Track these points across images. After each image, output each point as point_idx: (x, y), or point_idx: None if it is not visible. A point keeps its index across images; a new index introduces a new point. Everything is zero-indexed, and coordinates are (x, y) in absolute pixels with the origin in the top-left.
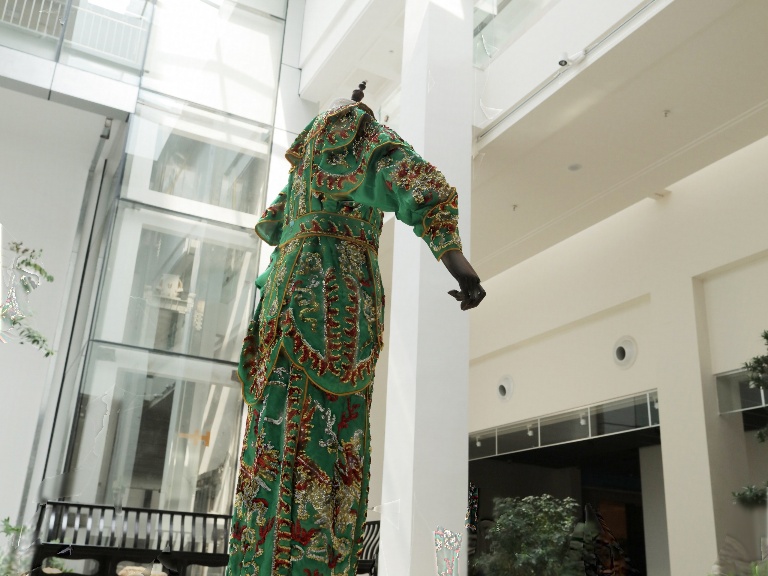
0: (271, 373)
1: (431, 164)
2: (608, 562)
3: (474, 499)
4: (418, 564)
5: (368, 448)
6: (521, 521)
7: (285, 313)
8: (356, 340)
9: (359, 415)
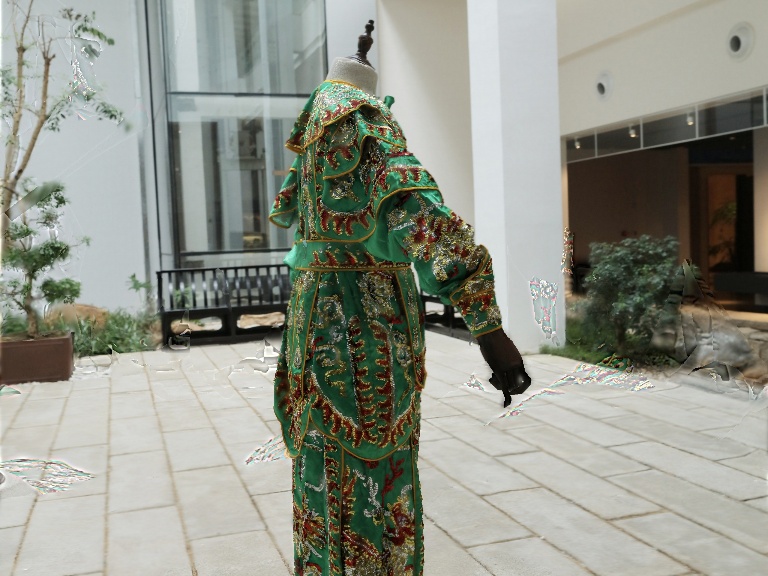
0: (305, 436)
1: (454, 221)
2: (706, 326)
3: (569, 244)
4: (516, 313)
5: (418, 497)
6: (618, 268)
7: (310, 370)
8: (391, 397)
9: (404, 470)
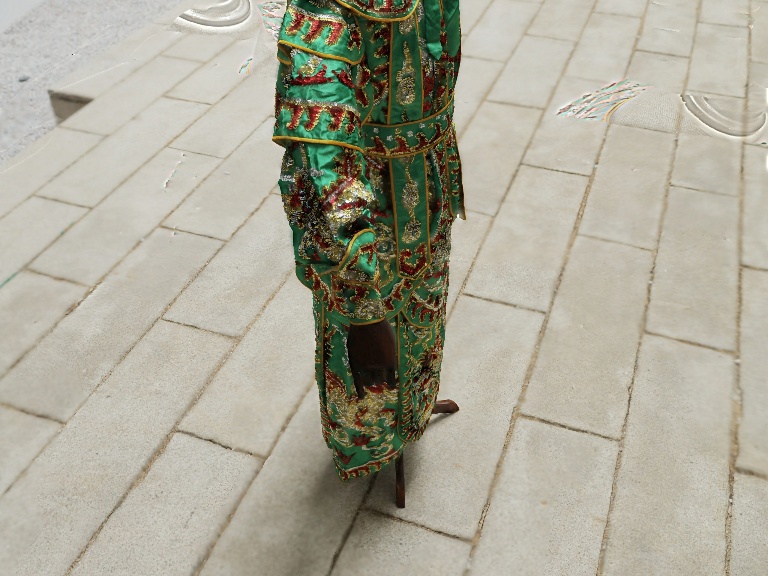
0: None
1: (321, 202)
2: None
3: None
4: None
5: (403, 364)
6: None
7: None
8: None
9: None
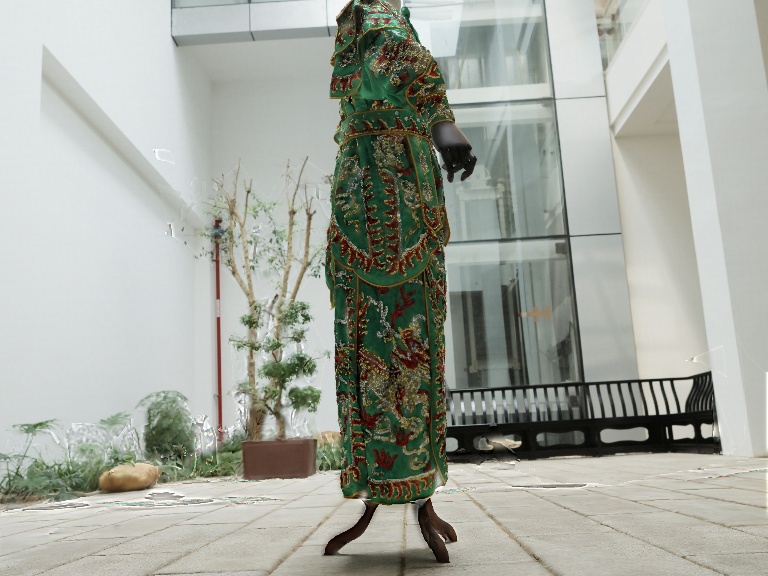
0: (335, 278)
1: (407, 39)
2: None
3: None
4: (756, 409)
5: (432, 330)
6: None
7: None
8: (398, 231)
9: (416, 301)
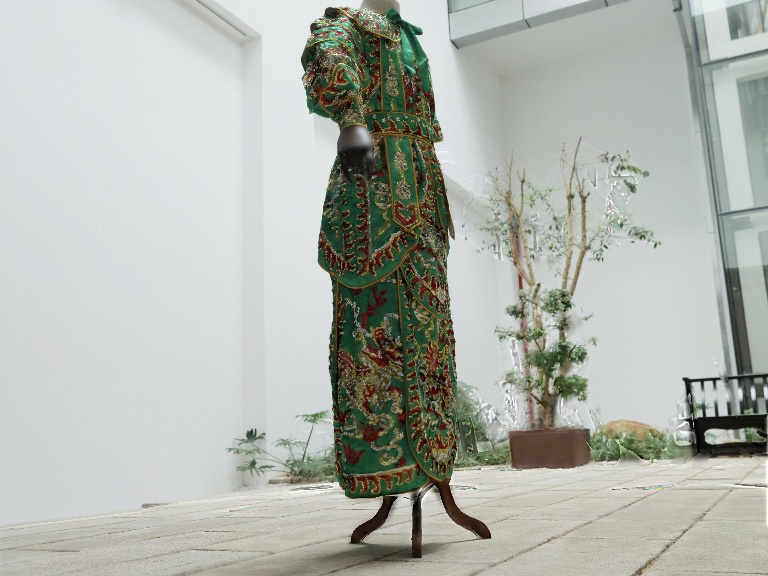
0: None
1: (324, 51)
2: None
3: None
4: None
5: (405, 327)
6: None
7: None
8: (368, 233)
9: (388, 300)
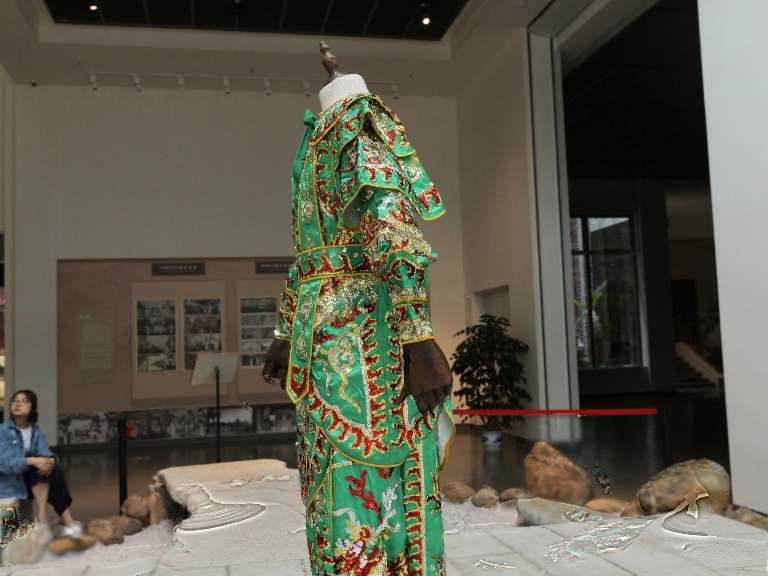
0: None
1: None
2: None
3: None
4: None
5: None
6: None
7: None
8: None
9: None
